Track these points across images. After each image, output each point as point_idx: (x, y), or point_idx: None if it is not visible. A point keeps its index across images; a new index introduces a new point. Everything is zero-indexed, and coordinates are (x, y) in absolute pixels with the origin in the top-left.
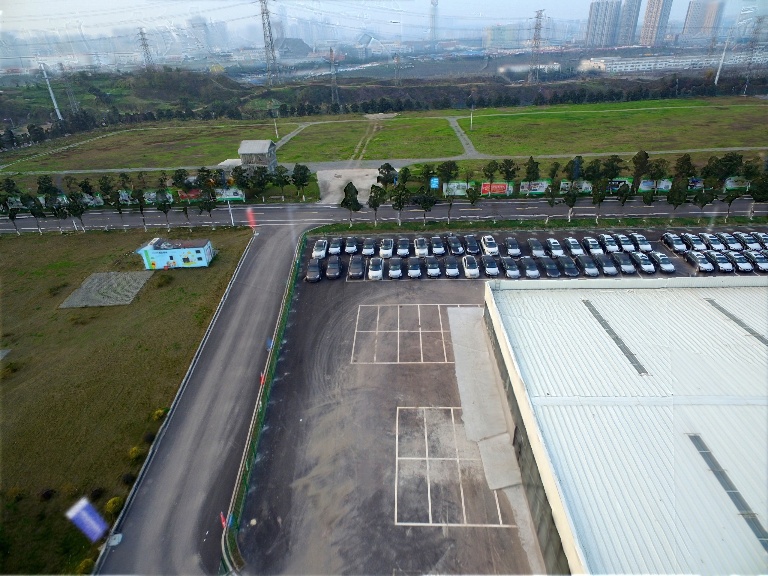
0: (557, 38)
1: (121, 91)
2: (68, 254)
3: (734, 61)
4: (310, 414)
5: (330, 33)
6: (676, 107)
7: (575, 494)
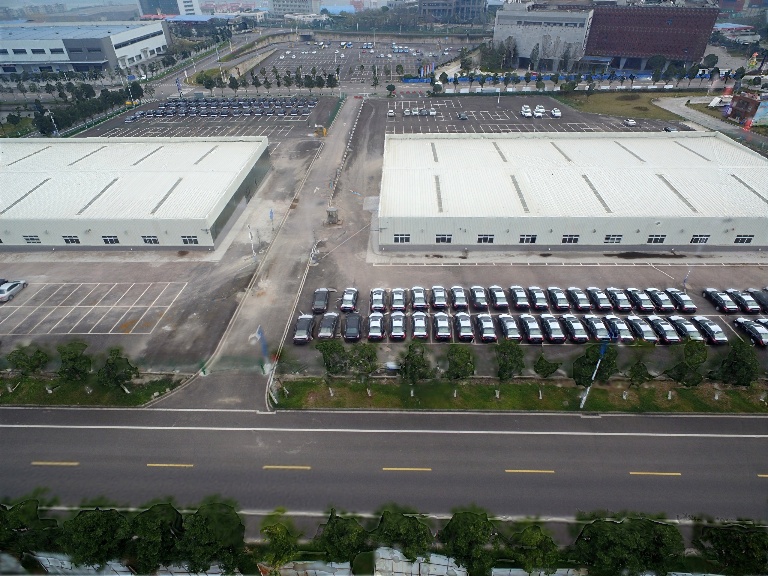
0: None
1: None
2: None
3: None
4: None
5: None
6: None
7: None
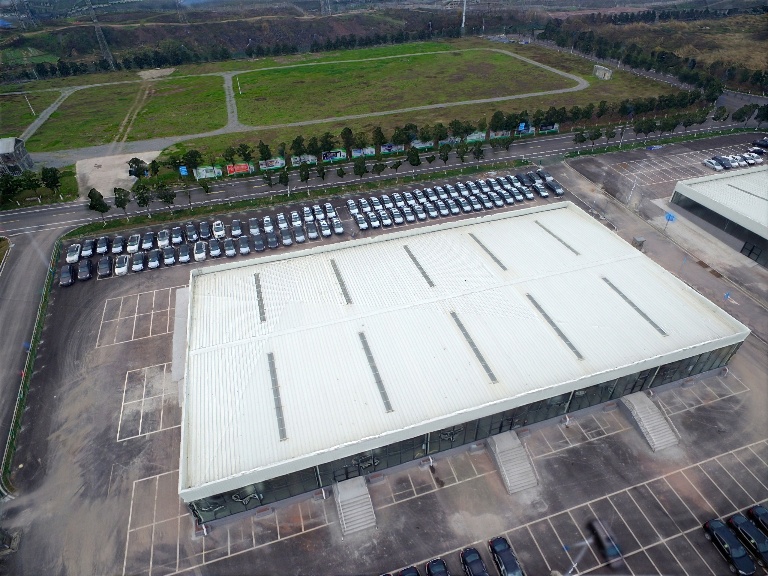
0: None
1: None
2: None
3: (476, 1)
4: (62, 391)
5: None
6: (424, 53)
7: (195, 400)
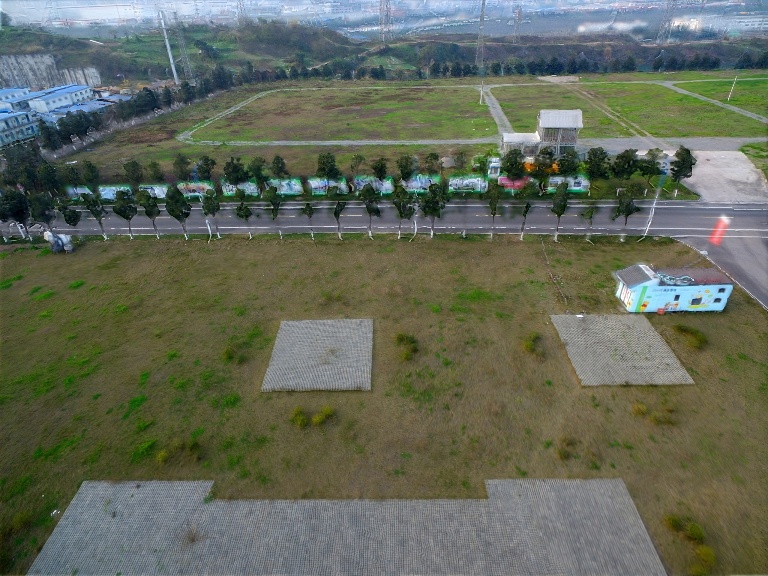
0: None
1: (227, 45)
2: (462, 276)
3: None
4: None
5: None
6: None
7: None
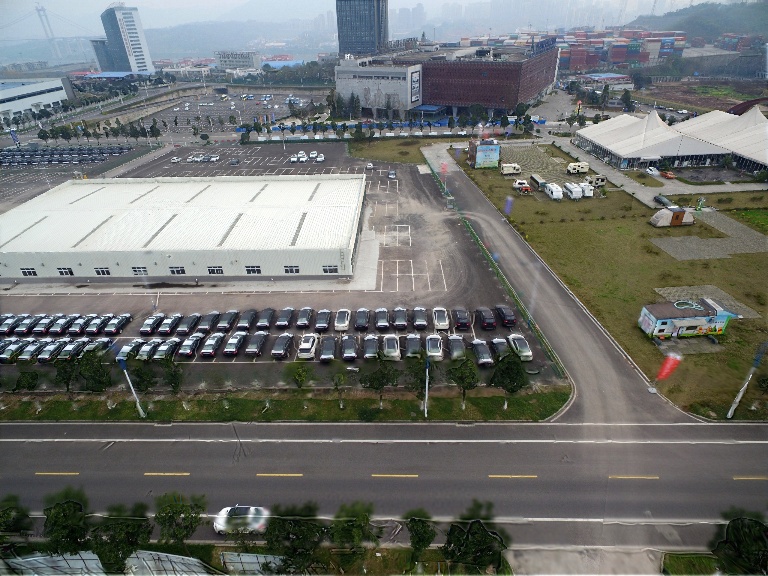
0: None
1: None
2: None
3: None
4: None
5: None
6: None
7: None
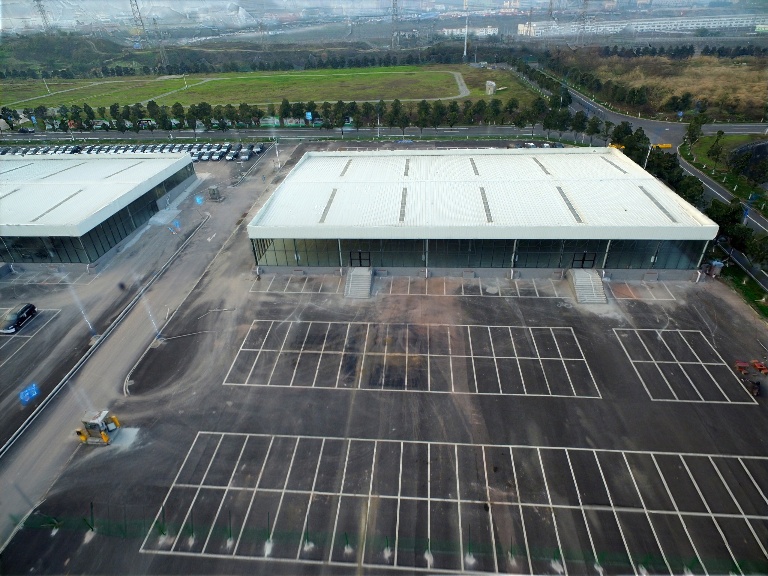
0: (412, 7)
1: (4, 53)
2: None
3: (485, 33)
4: None
5: (198, 1)
6: (385, 72)
7: None
